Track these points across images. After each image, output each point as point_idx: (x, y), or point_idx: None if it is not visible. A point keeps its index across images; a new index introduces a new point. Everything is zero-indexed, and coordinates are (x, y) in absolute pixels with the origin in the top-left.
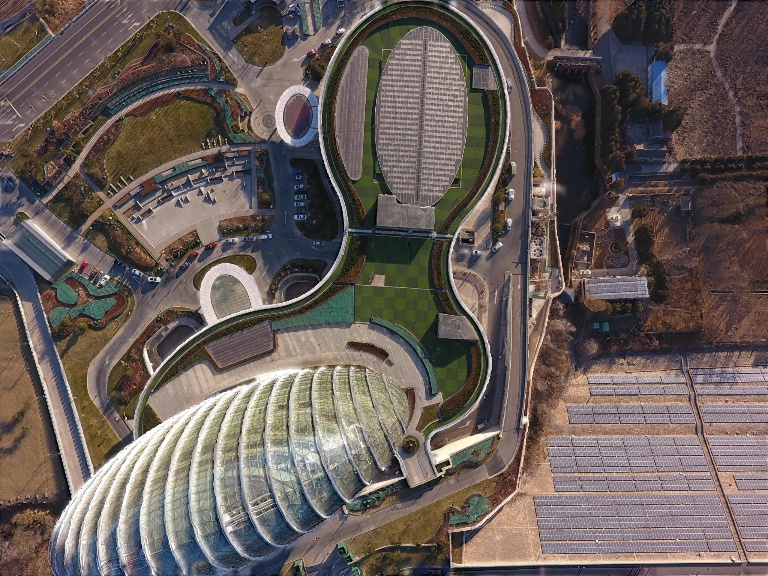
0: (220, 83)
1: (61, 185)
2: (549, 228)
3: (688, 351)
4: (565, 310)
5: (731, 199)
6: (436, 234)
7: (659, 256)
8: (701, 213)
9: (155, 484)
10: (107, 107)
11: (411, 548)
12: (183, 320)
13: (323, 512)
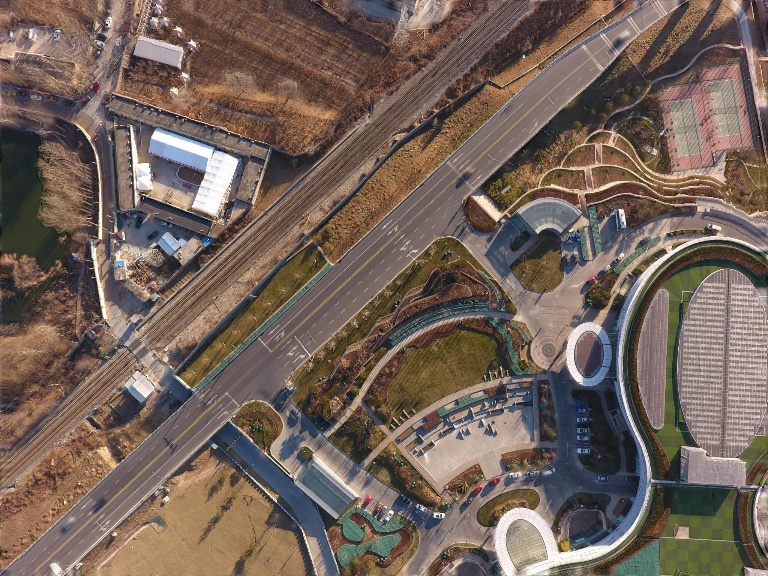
0: (499, 312)
1: (343, 418)
2: None
3: None
4: None
5: None
6: None
7: None
8: None
9: None
10: (388, 339)
11: None
12: (468, 557)
13: None
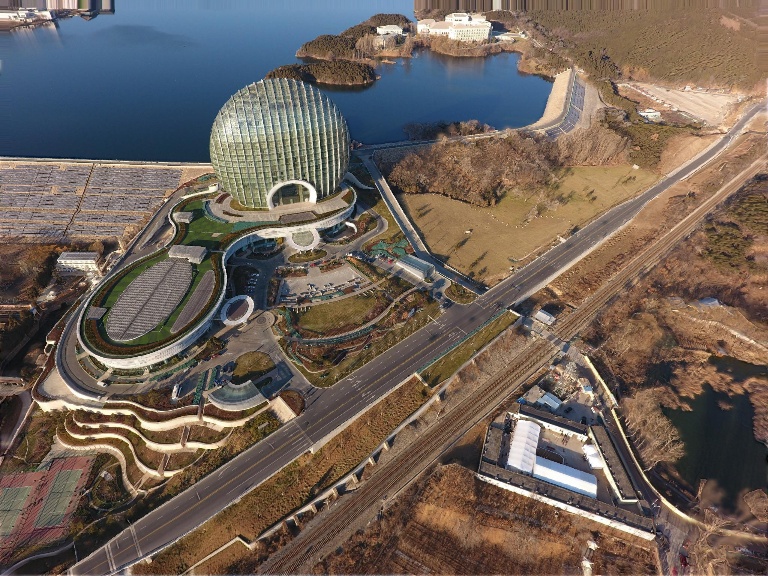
0: None
1: None
2: None
3: None
4: None
5: None
6: None
7: None
8: None
9: (287, 96)
10: None
11: None
12: None
13: None
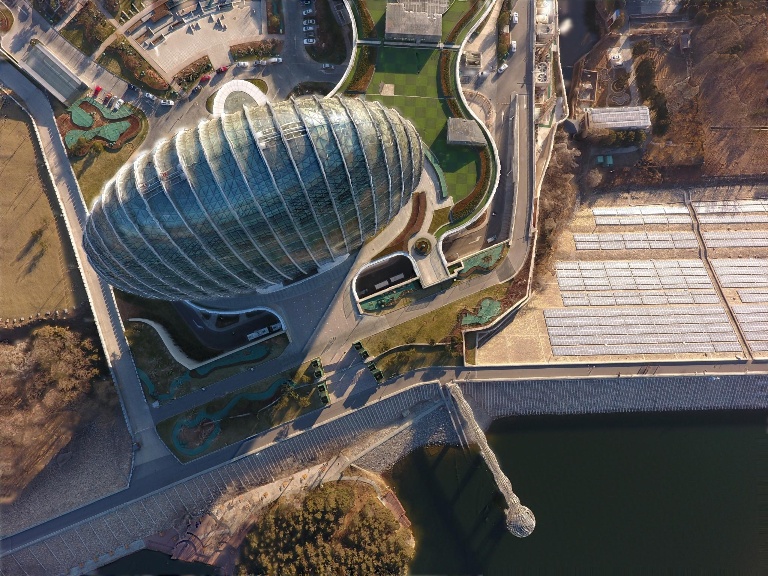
0: None
1: (74, 13)
2: (552, 59)
3: (690, 185)
4: (570, 142)
5: (729, 30)
6: (443, 45)
7: None
8: (700, 51)
9: None
10: None
11: (425, 348)
12: None
13: (349, 172)
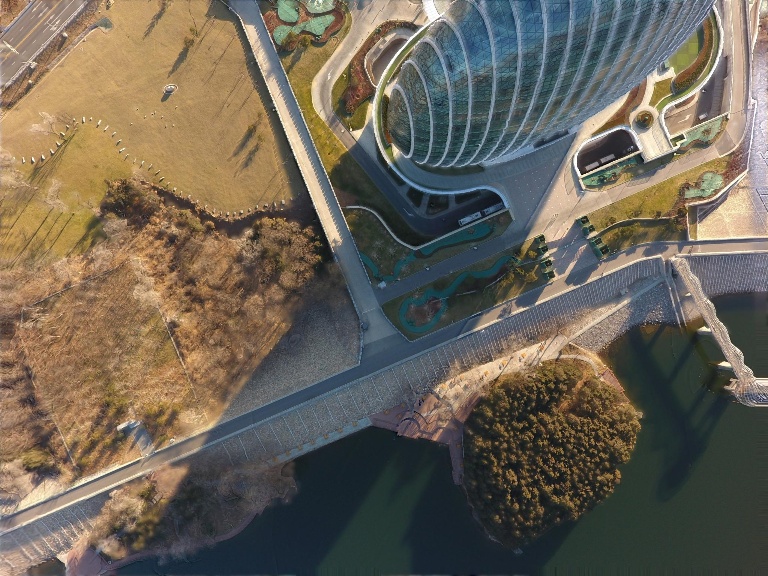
0: None
1: None
2: None
3: None
4: None
5: None
6: None
7: None
8: None
9: None
10: None
11: (648, 223)
12: (400, 31)
13: None
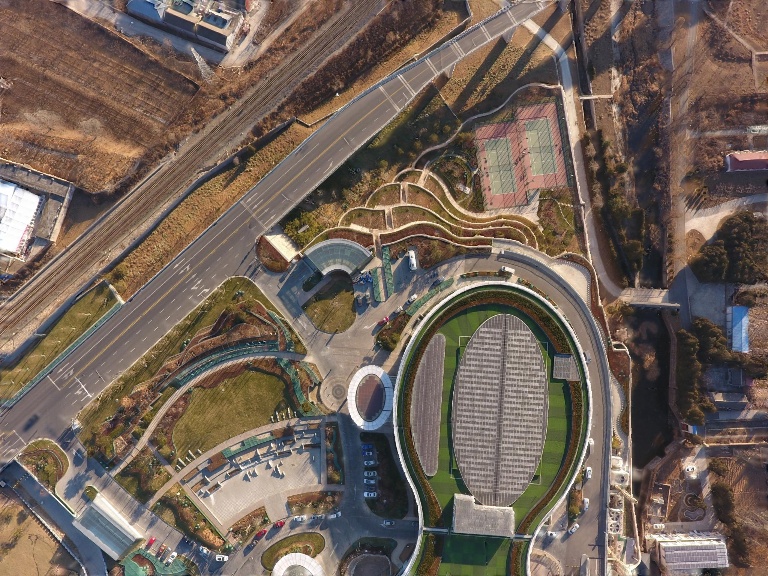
0: (289, 352)
1: (129, 458)
2: None
3: None
4: (639, 574)
5: None
6: (514, 534)
7: (737, 509)
8: None
9: None
10: (176, 379)
11: None
12: None
13: None
